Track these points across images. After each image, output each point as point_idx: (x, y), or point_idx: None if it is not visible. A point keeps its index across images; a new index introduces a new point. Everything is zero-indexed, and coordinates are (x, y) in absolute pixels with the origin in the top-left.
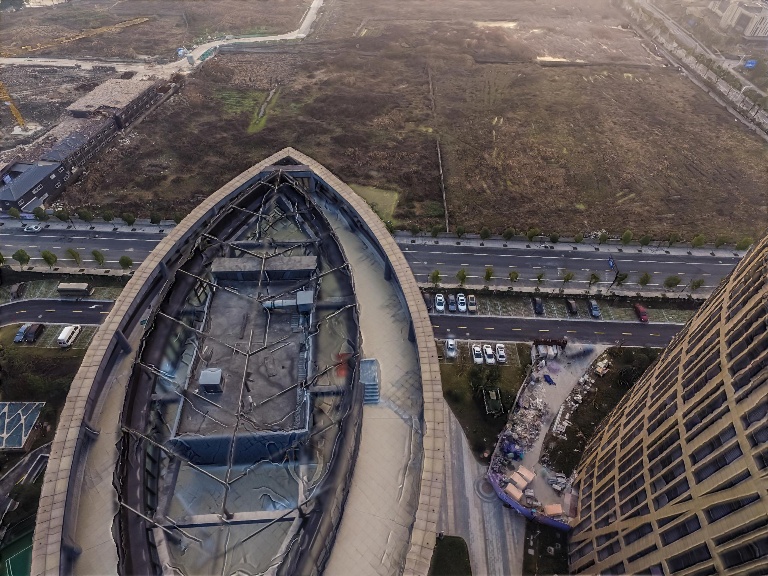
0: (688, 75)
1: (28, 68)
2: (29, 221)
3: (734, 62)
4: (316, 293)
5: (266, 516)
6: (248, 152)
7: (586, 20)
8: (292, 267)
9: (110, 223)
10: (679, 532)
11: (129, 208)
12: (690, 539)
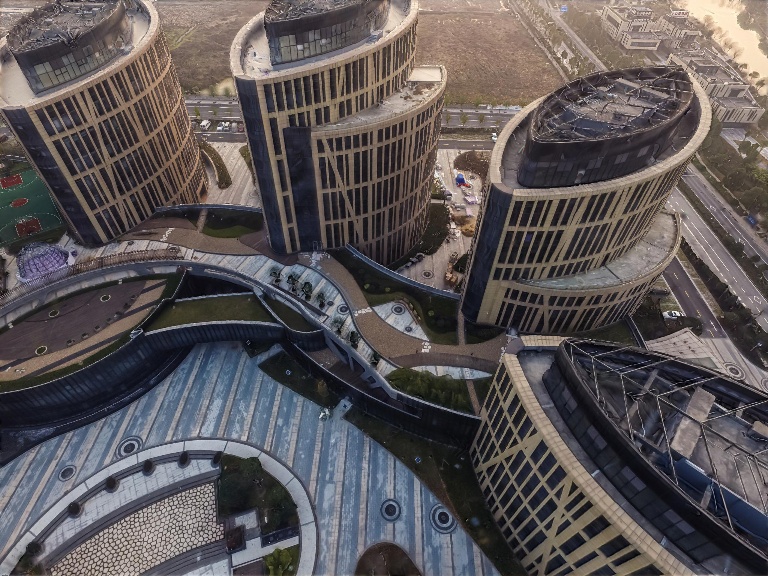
0: (520, 19)
1: (3, 14)
2: None
3: None
4: None
5: (57, 39)
6: None
7: None
8: (95, 4)
9: None
10: None
11: None
12: None
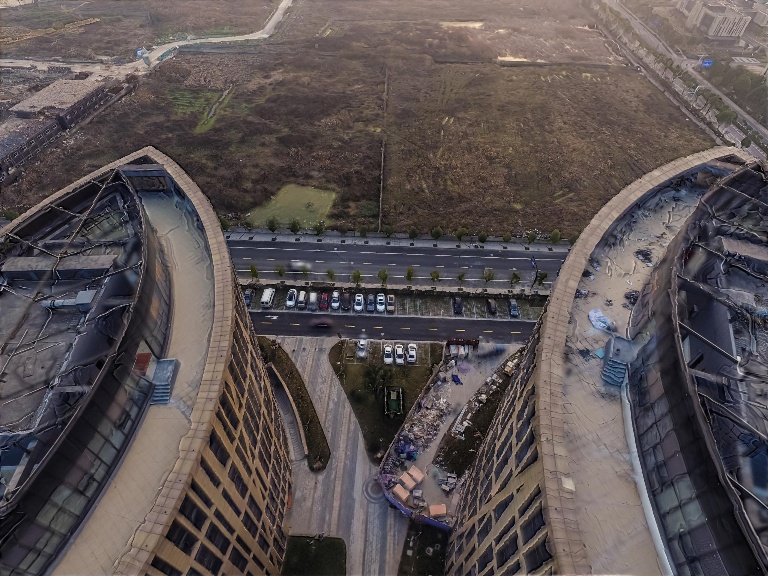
0: (646, 75)
1: None
2: None
3: (695, 62)
4: (100, 292)
5: None
6: (191, 152)
7: (553, 20)
8: (86, 266)
9: None
10: (484, 532)
11: None
12: (487, 540)
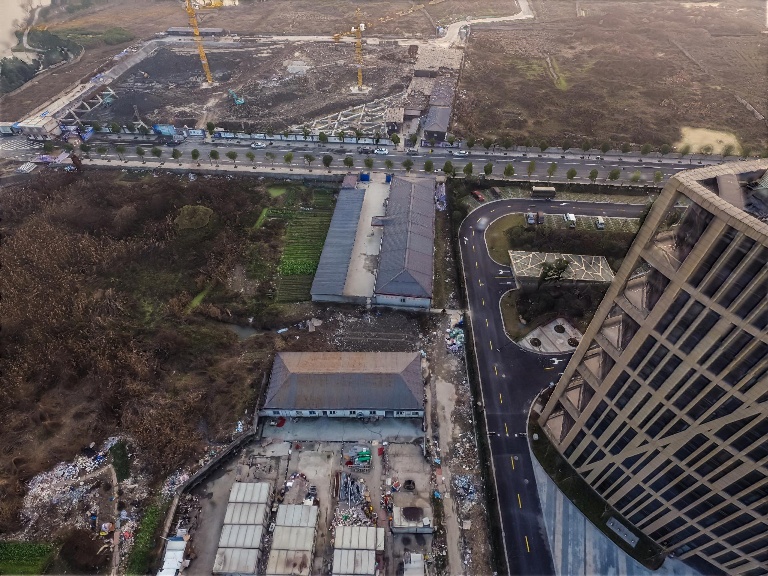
0: None
1: (324, 44)
2: (451, 149)
3: None
4: None
5: None
6: (577, 103)
7: None
8: None
9: (517, 151)
10: None
11: (523, 141)
12: None
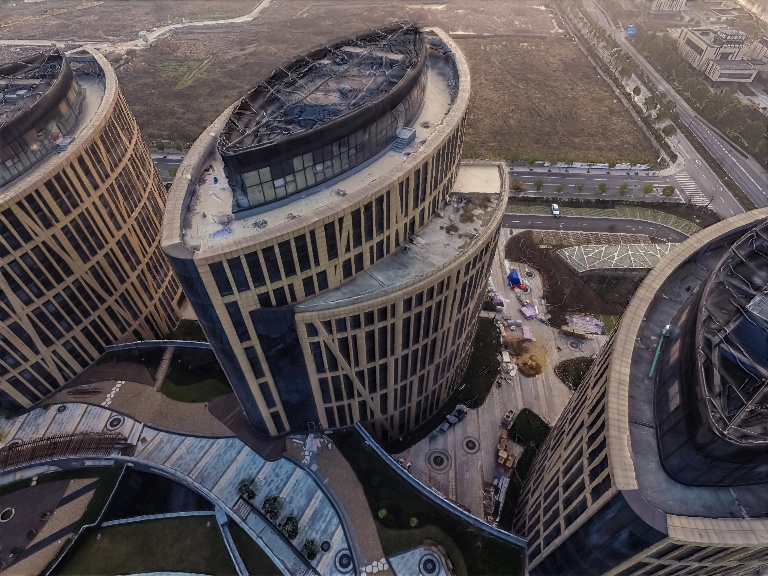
0: (578, 43)
1: (14, 47)
2: None
3: None
4: (30, 92)
5: None
6: (167, 103)
7: (512, 1)
8: (25, 82)
9: None
10: None
11: None
12: None
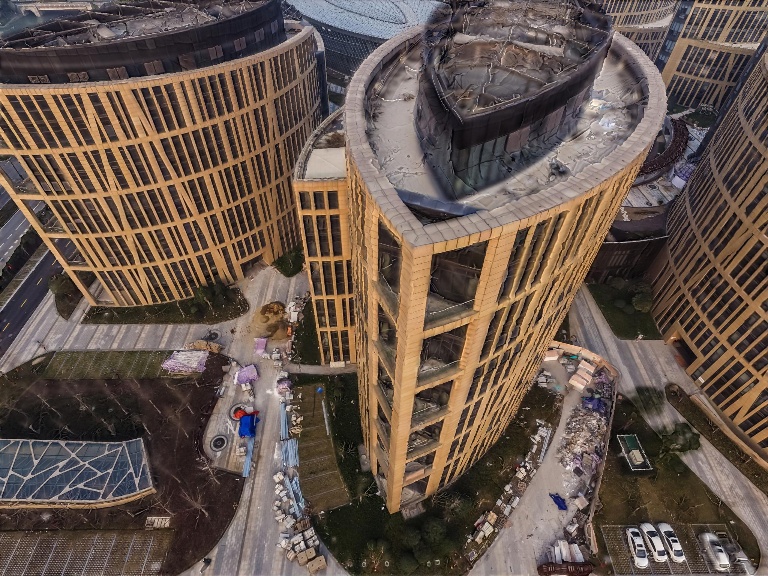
0: None
1: None
2: None
3: None
4: None
5: None
6: None
7: None
8: None
9: None
10: None
11: None
12: None
